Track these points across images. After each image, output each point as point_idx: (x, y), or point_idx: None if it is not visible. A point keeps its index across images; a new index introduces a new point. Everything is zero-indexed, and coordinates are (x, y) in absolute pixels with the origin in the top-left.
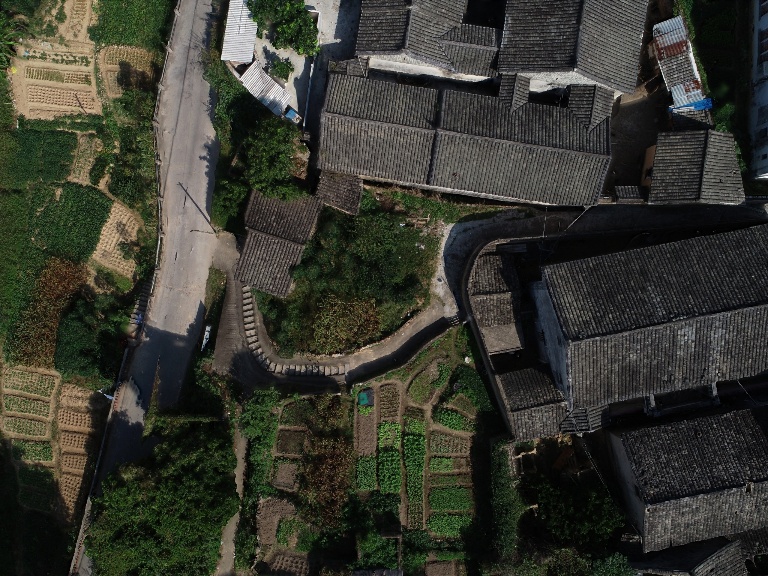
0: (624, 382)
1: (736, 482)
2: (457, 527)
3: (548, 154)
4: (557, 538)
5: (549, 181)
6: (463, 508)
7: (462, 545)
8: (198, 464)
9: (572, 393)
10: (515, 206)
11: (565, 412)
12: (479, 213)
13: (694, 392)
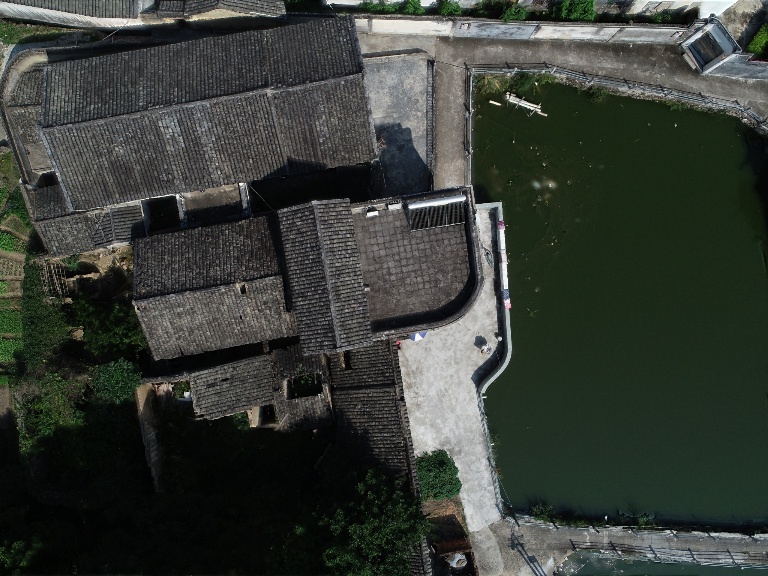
0: (120, 180)
1: (227, 281)
2: (11, 351)
3: None
4: (96, 357)
5: None
6: (16, 331)
7: (14, 368)
8: None
9: (66, 190)
10: (81, 29)
11: (94, 224)
12: (41, 34)
13: (232, 208)
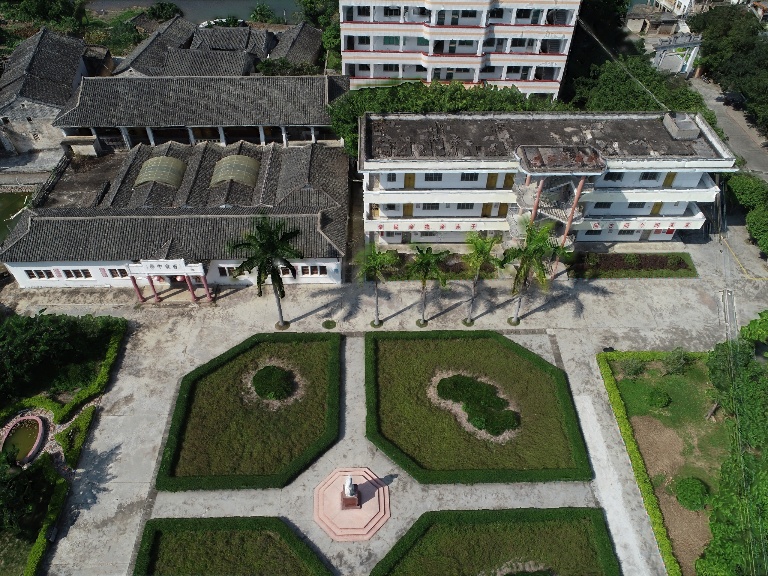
0: None
1: None
2: None
3: None
4: None
5: None
6: None
7: None
8: (55, 4)
9: None
10: None
11: None
12: None
13: None
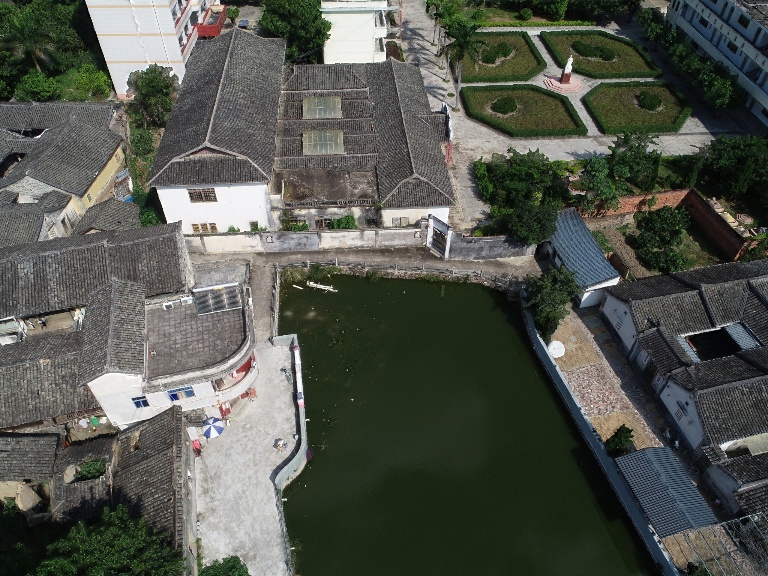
0: None
1: None
2: None
3: (2, 215)
4: None
5: (2, 232)
6: None
7: None
8: None
9: None
10: None
11: None
12: None
13: None
